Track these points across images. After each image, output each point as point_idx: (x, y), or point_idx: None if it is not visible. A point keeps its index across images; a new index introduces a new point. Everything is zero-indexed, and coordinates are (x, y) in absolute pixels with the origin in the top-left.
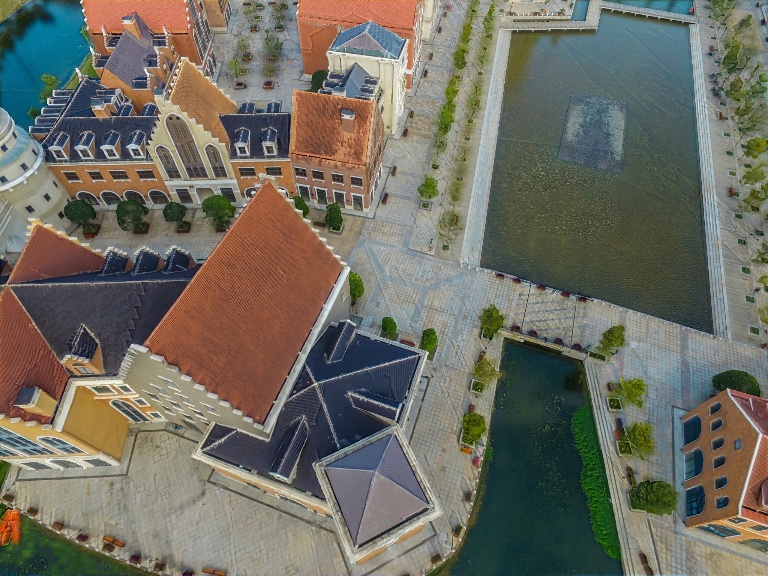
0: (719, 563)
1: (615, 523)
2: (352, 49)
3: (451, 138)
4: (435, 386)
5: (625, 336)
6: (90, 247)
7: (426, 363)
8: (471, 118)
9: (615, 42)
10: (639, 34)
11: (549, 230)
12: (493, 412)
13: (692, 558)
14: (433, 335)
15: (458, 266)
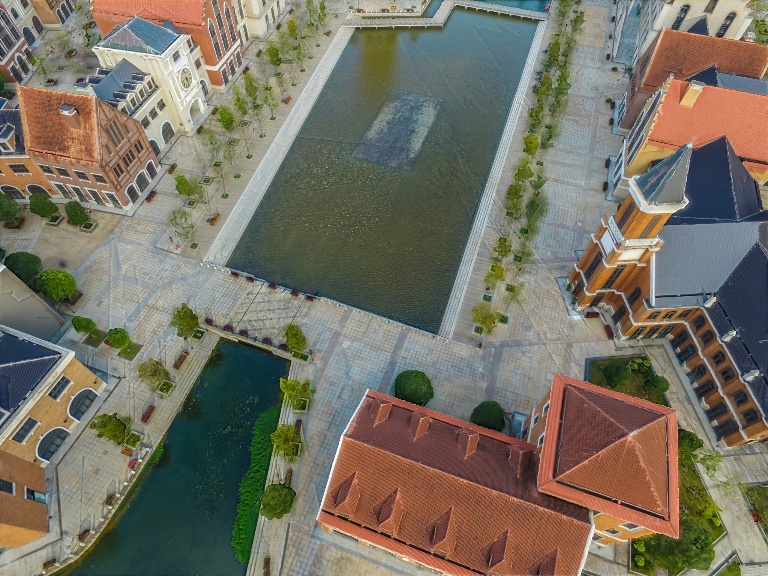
0: (344, 568)
1: (255, 527)
2: (116, 45)
3: (246, 135)
4: (124, 387)
5: (340, 336)
6: None
7: (124, 363)
8: (274, 115)
9: (457, 39)
10: (484, 31)
11: (312, 228)
12: (178, 413)
13: (318, 563)
14: (115, 335)
15: (199, 265)
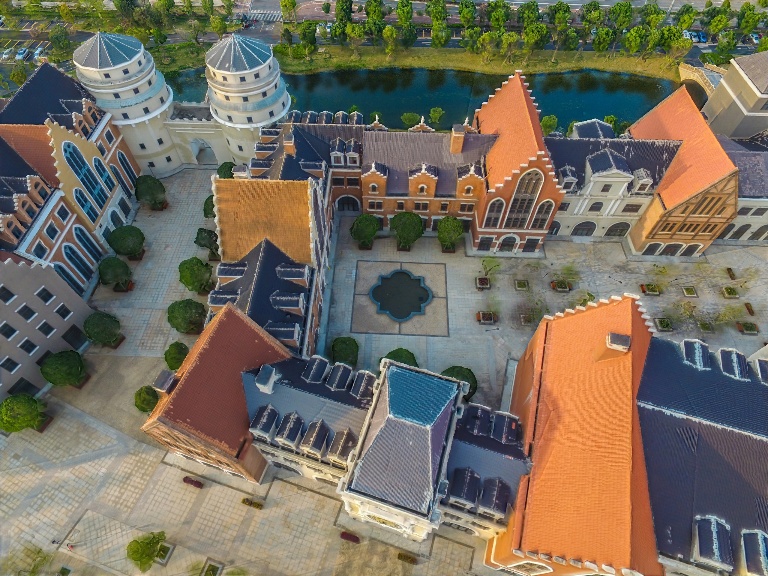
0: None
1: None
2: None
3: None
4: None
5: None
6: (58, 168)
7: None
8: None
9: None
10: None
11: None
12: None
13: None
14: None
15: None
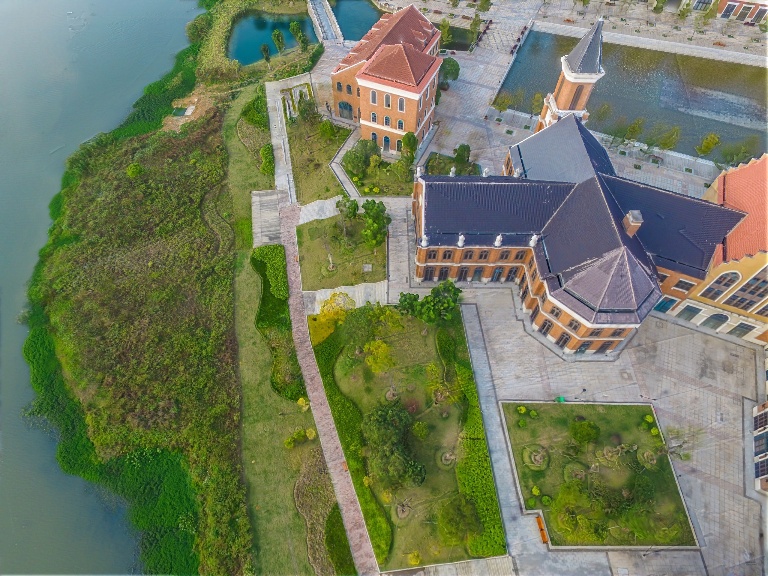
0: None
1: None
2: None
3: (662, 29)
4: None
5: (487, 64)
6: None
7: (464, 5)
8: None
9: None
10: None
11: None
12: (439, 24)
13: None
14: None
15: None
